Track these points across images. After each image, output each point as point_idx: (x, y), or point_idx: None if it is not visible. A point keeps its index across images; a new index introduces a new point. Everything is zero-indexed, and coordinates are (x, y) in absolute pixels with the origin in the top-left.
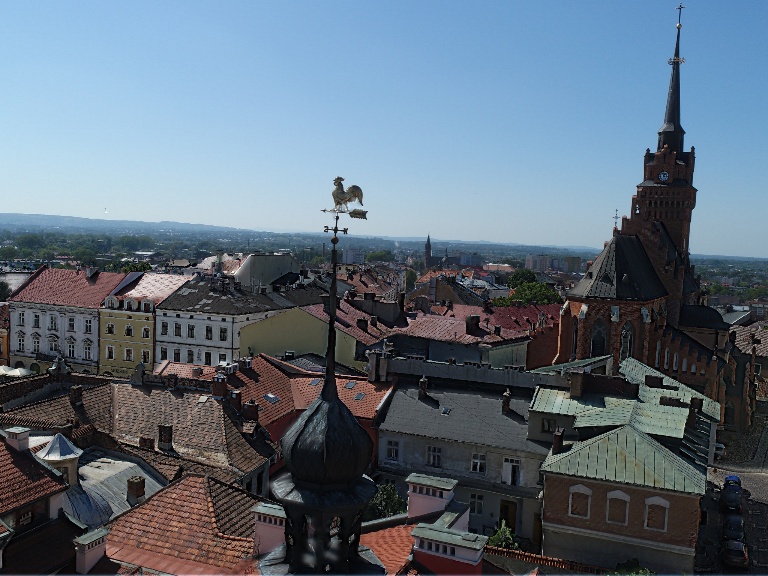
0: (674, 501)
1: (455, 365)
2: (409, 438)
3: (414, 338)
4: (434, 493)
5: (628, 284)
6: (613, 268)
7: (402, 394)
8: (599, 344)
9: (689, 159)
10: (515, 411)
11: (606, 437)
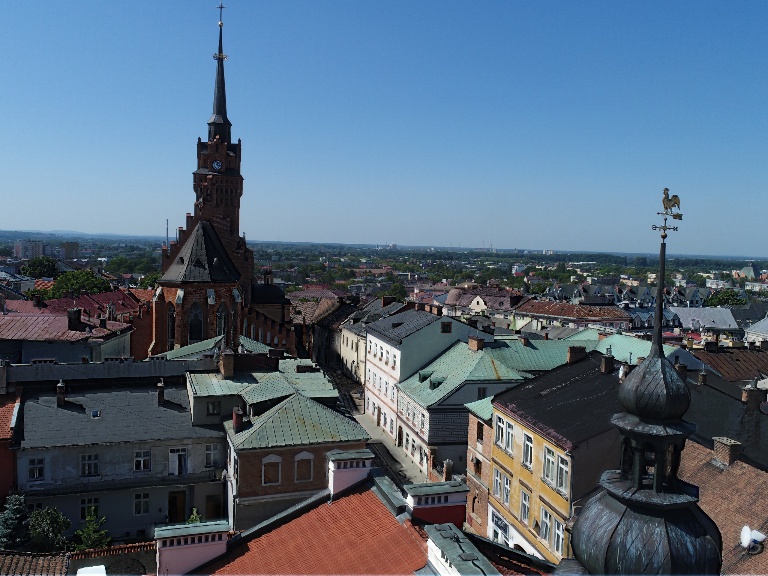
0: None
1: (94, 363)
2: (58, 451)
3: (2, 341)
4: (358, 465)
5: (219, 267)
6: (203, 253)
7: (34, 405)
8: (196, 327)
9: (238, 150)
10: (170, 401)
11: (283, 407)
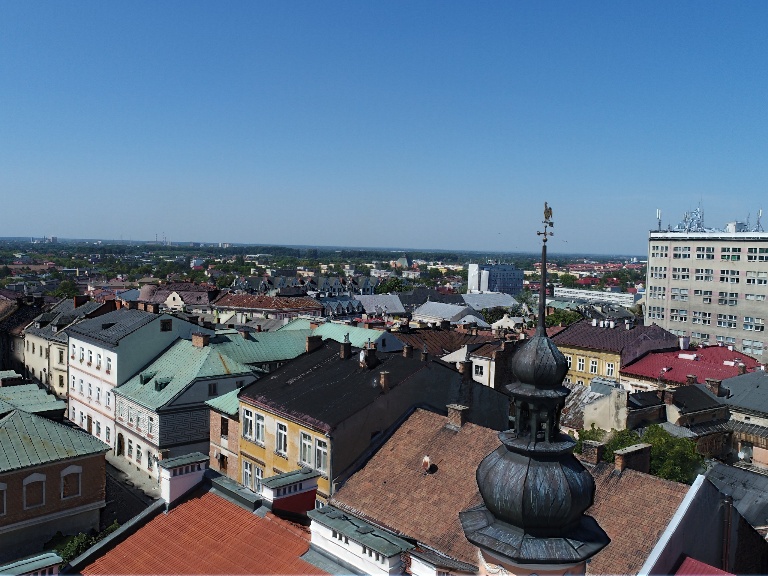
0: (86, 464)
1: None
2: None
3: None
4: (193, 469)
5: None
6: None
7: None
8: None
9: None
10: None
11: (2, 427)
